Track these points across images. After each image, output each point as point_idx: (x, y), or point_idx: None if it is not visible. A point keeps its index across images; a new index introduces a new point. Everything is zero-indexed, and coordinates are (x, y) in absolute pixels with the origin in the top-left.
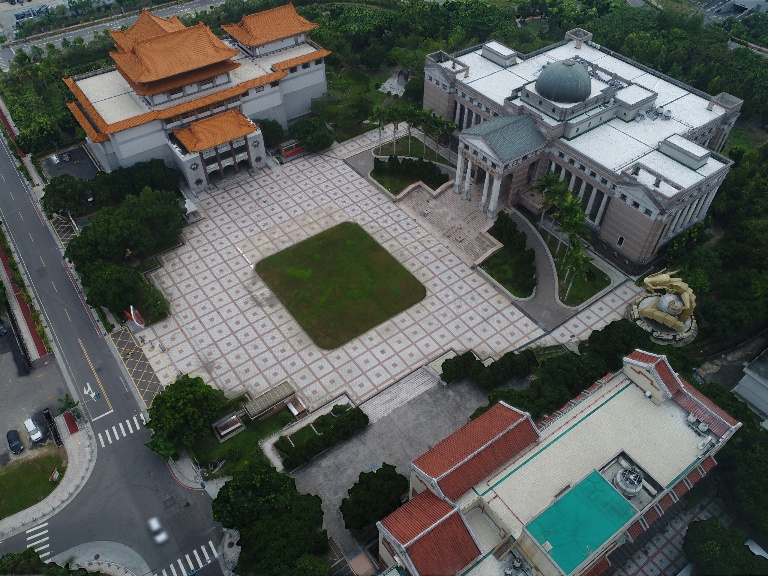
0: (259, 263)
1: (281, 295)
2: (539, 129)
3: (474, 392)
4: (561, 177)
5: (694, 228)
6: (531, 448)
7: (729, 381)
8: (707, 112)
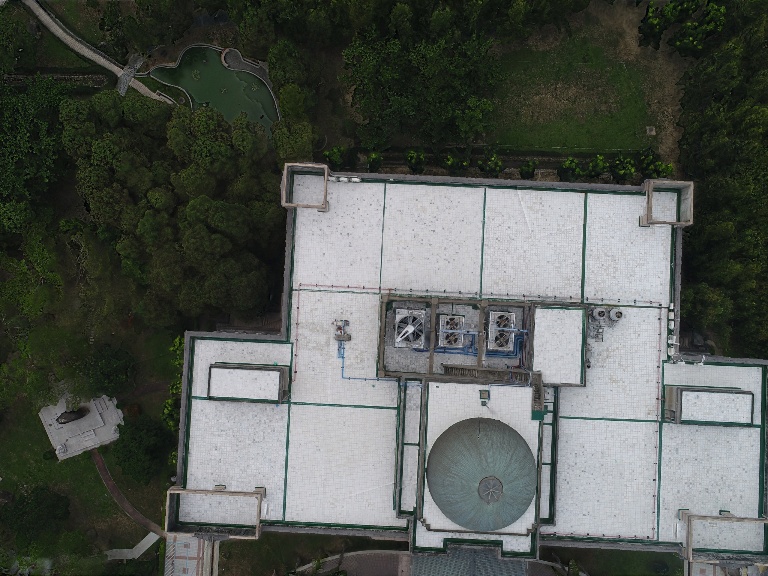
0: None
1: None
2: None
3: None
4: None
5: None
6: None
7: None
8: (647, 236)
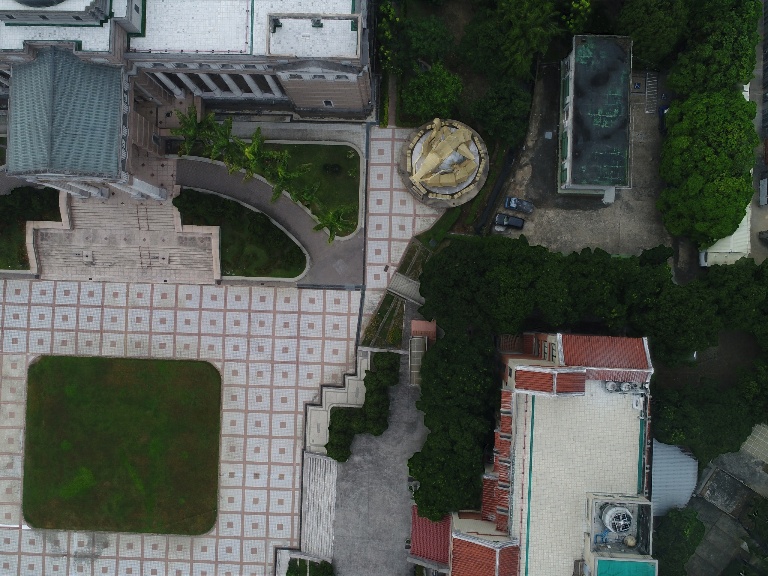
0: (26, 517)
1: (97, 525)
2: (91, 62)
3: (373, 436)
4: (183, 80)
5: (385, 6)
6: (519, 556)
7: (549, 175)
8: None
